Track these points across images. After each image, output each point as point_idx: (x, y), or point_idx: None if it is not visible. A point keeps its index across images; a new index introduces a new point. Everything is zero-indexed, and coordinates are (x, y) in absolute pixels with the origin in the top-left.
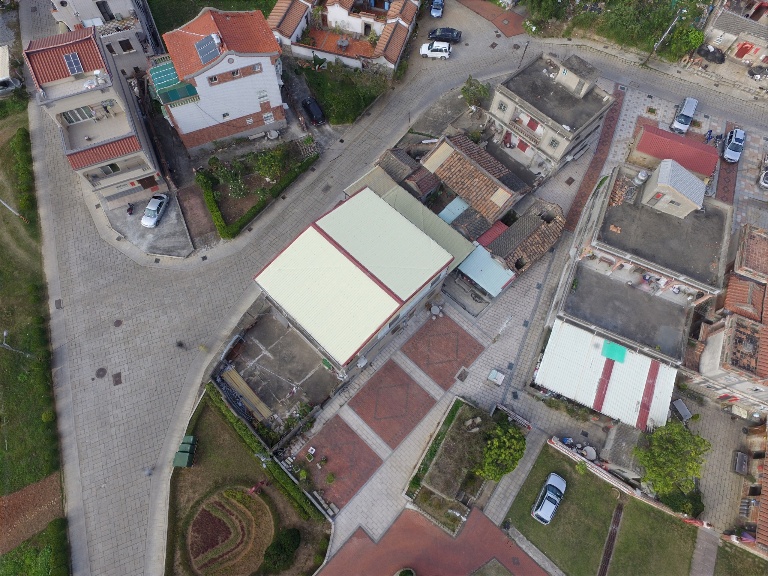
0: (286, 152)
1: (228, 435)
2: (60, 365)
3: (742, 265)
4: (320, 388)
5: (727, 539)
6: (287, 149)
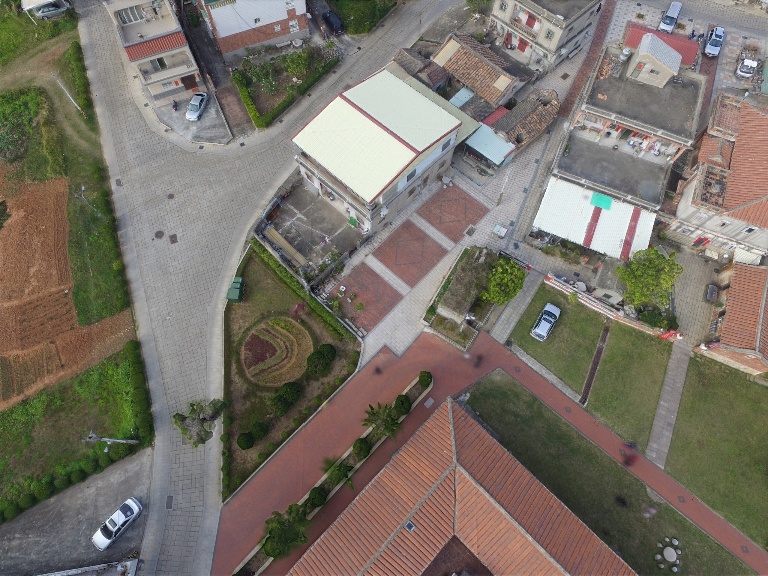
0: (311, 54)
1: (271, 280)
2: (124, 229)
3: (714, 125)
4: (348, 242)
5: (697, 350)
6: (312, 51)
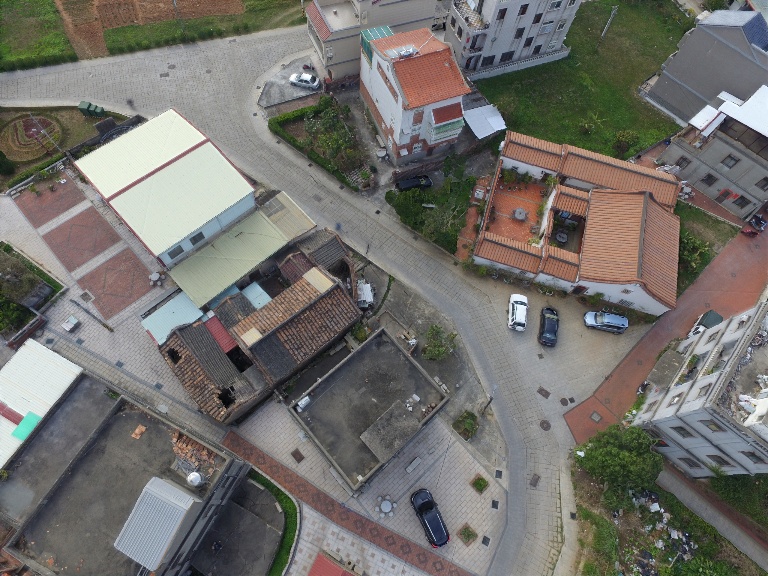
0: None
1: None
2: (184, 47)
3: None
4: None
5: None
6: (351, 156)
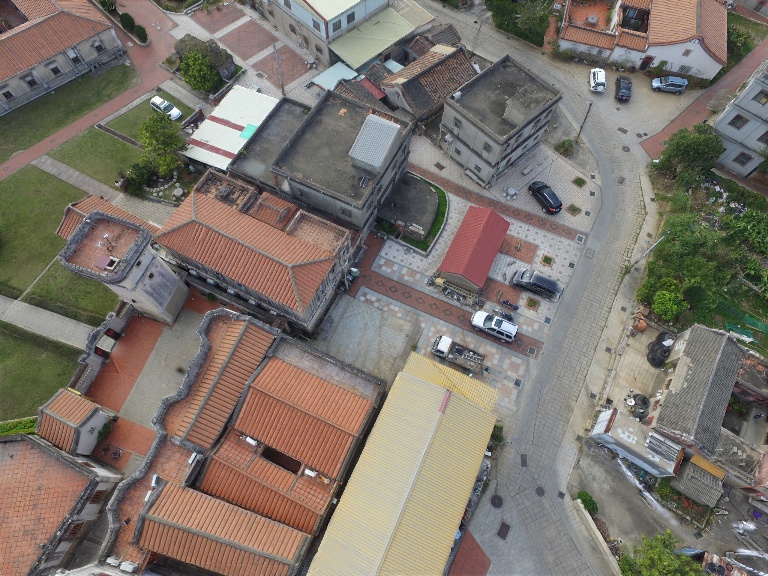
0: None
1: None
2: None
3: None
4: None
5: None
6: None
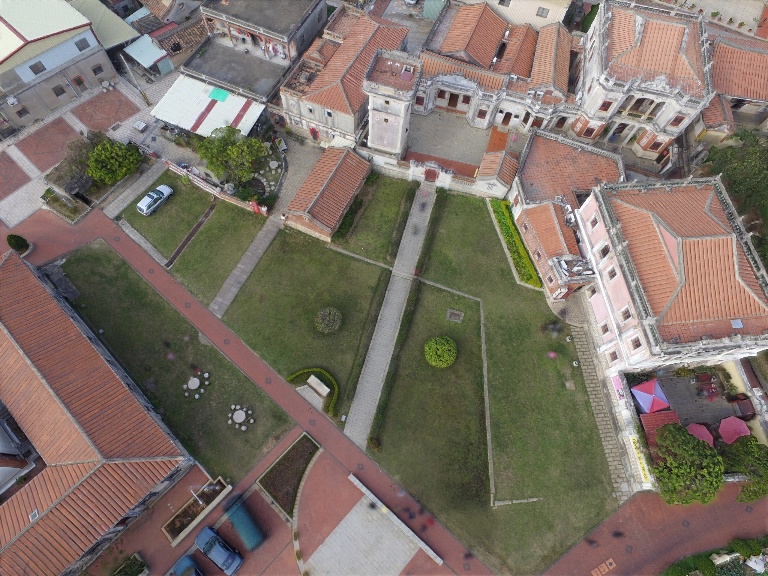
0: None
1: None
2: None
3: (324, 29)
4: None
5: (284, 221)
6: None
